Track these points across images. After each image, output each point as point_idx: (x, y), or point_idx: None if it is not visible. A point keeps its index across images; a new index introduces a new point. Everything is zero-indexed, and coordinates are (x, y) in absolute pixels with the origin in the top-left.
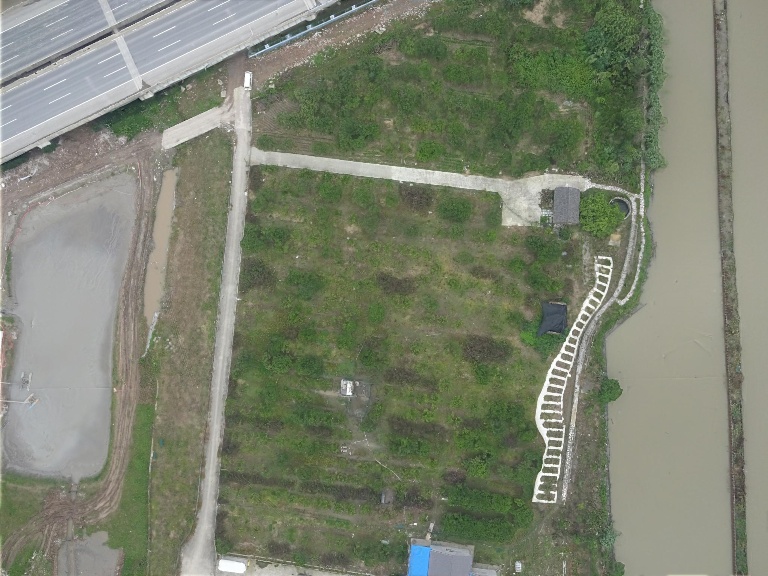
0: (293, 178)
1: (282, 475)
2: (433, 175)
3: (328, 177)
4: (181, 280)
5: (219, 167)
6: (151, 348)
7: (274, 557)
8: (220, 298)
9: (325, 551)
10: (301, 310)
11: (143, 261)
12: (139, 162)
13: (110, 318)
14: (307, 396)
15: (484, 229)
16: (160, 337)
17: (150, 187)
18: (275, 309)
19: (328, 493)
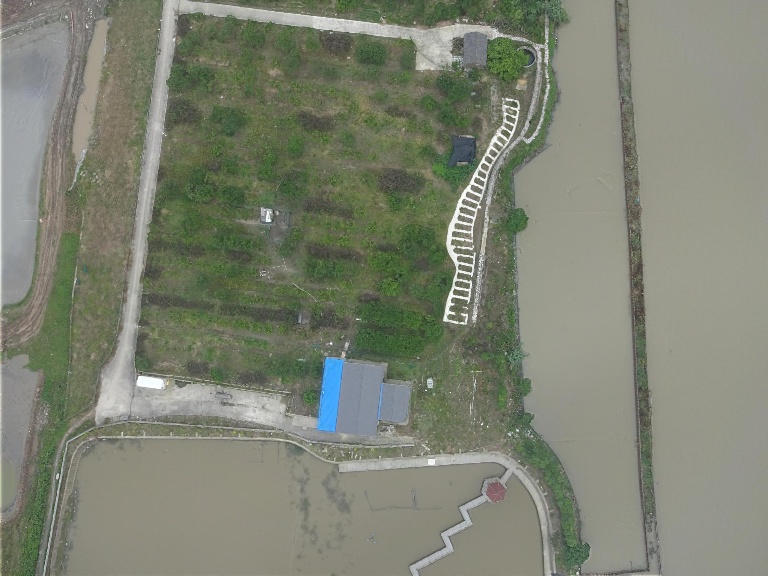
0: (219, 26)
1: (202, 298)
2: (352, 24)
3: (252, 23)
4: (109, 120)
5: (149, 17)
6: (78, 181)
7: (193, 376)
8: (146, 135)
9: (243, 370)
10: (224, 145)
11: (73, 102)
12: (72, 11)
13: (39, 155)
14: (228, 223)
15: (398, 70)
16: (87, 170)
17: (82, 34)
18: (199, 144)
19: (247, 315)
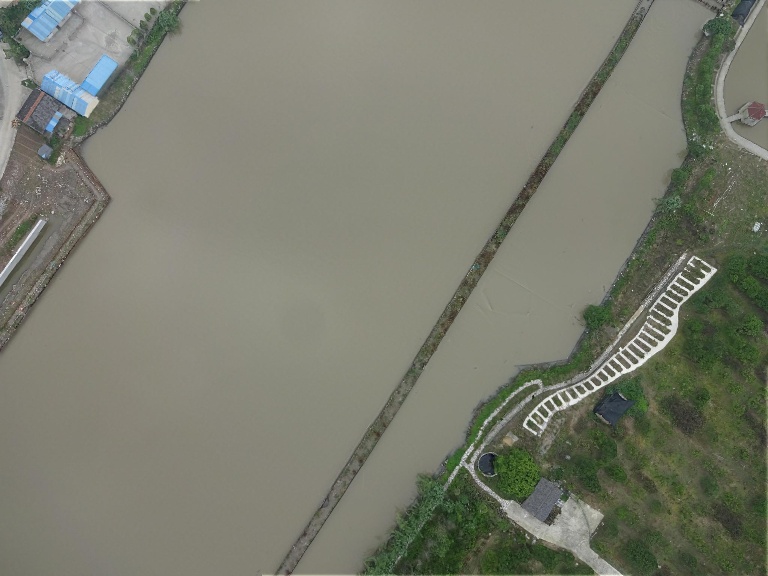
0: None
1: None
2: None
3: None
4: None
5: None
6: None
7: None
8: None
9: None
10: None
11: None
12: None
13: None
14: None
15: None
16: None
17: None
18: None
19: None
